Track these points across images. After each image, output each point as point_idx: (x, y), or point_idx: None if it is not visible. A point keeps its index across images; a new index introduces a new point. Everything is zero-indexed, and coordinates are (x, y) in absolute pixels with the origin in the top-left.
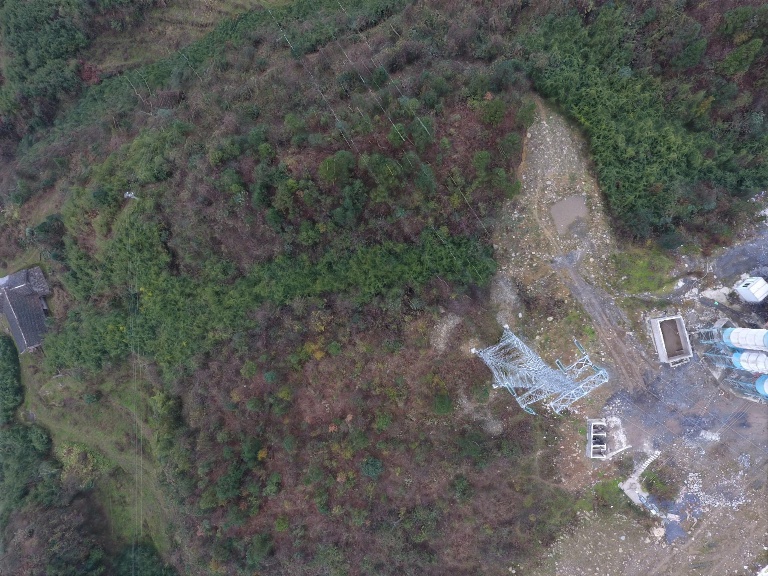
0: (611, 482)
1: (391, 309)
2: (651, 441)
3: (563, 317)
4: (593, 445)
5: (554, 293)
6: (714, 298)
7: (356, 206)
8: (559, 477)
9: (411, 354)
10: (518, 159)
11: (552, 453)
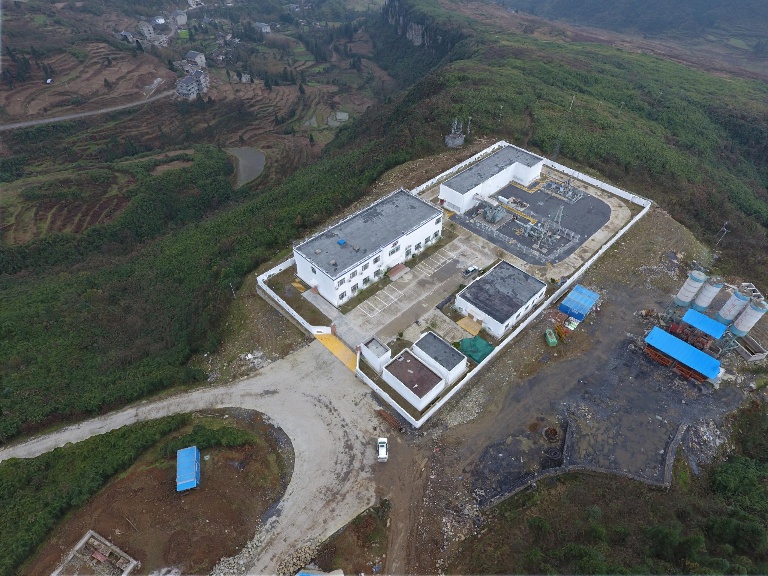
0: None
1: None
2: None
3: None
4: (755, 289)
5: None
6: None
7: None
8: None
9: None
10: None
11: (762, 291)
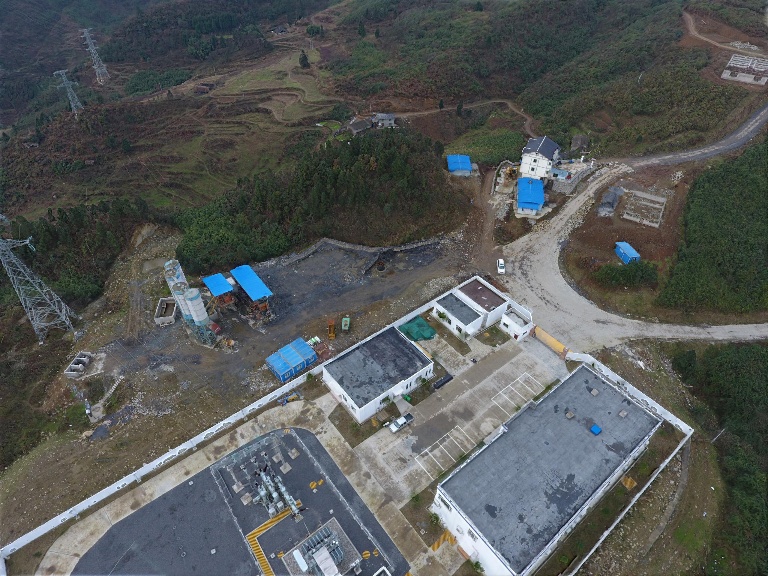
0: (80, 405)
1: (5, 299)
2: (120, 369)
3: (117, 310)
4: (72, 364)
5: (120, 299)
6: (210, 295)
7: (28, 255)
8: (43, 401)
9: (1, 327)
10: (129, 234)
11: (48, 382)
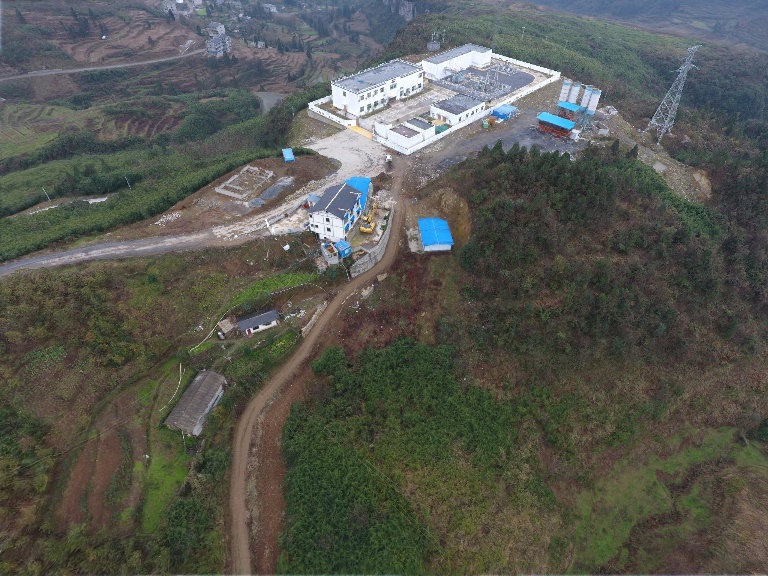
0: None
1: None
2: None
3: None
4: (614, 108)
5: None
6: None
7: None
8: None
9: None
10: None
11: None
